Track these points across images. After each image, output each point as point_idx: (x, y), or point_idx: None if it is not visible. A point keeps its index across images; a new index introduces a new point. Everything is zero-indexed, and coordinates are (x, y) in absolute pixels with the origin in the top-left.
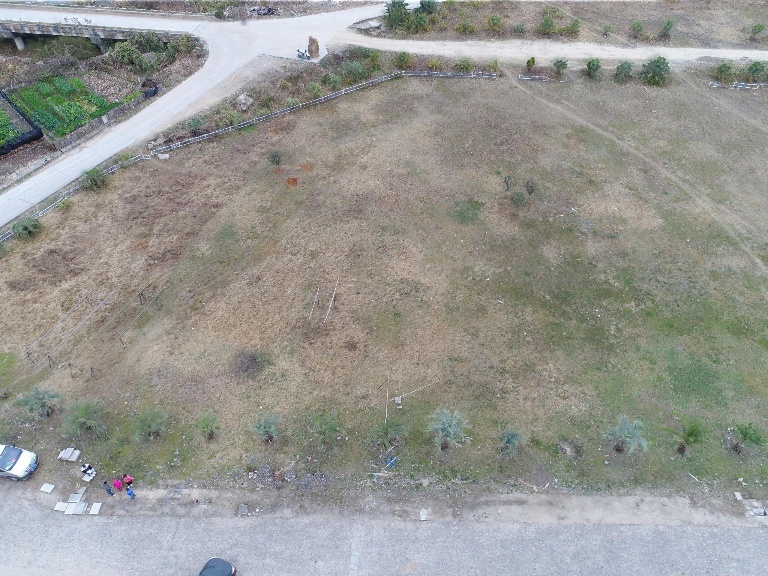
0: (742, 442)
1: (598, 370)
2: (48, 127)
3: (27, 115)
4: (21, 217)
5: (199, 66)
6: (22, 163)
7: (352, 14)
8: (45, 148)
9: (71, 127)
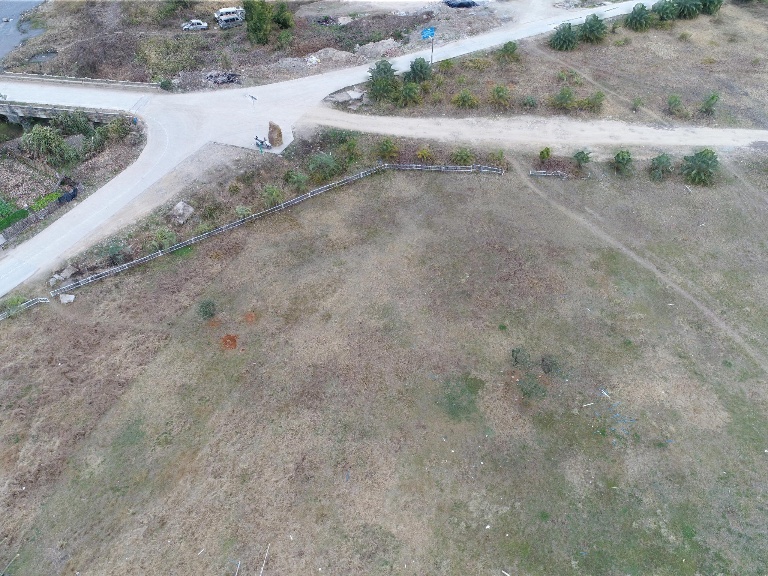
0: None
1: None
2: None
3: None
4: None
5: (133, 158)
6: None
7: (329, 80)
8: None
9: None
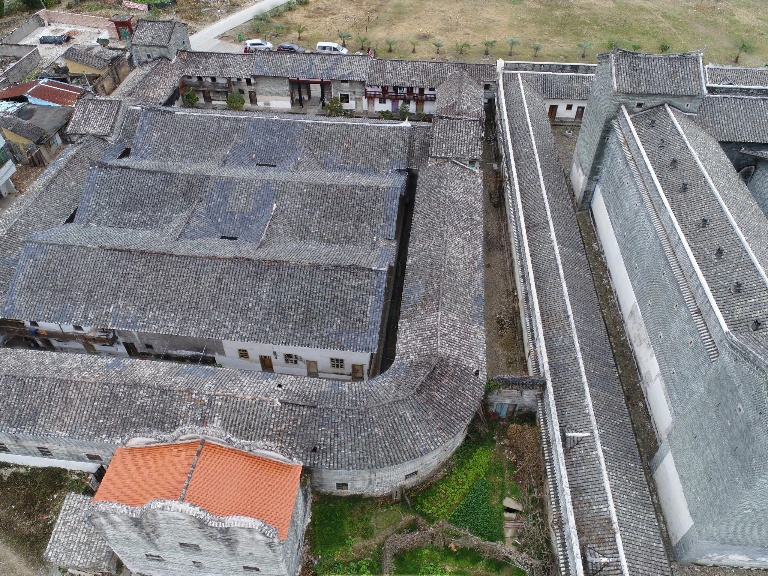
0: None
1: None
2: None
3: None
4: None
5: None
6: None
7: None
8: None
9: None
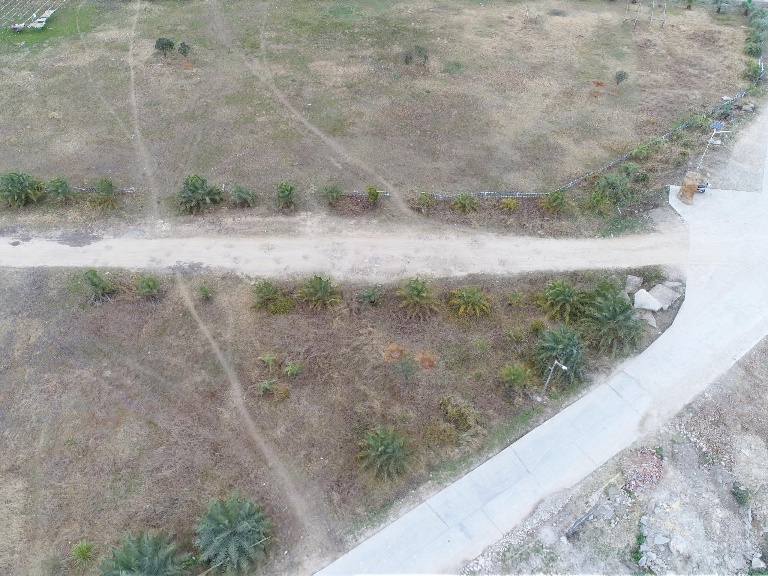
0: None
1: None
2: None
3: None
4: None
5: None
6: None
7: (712, 341)
8: None
9: None
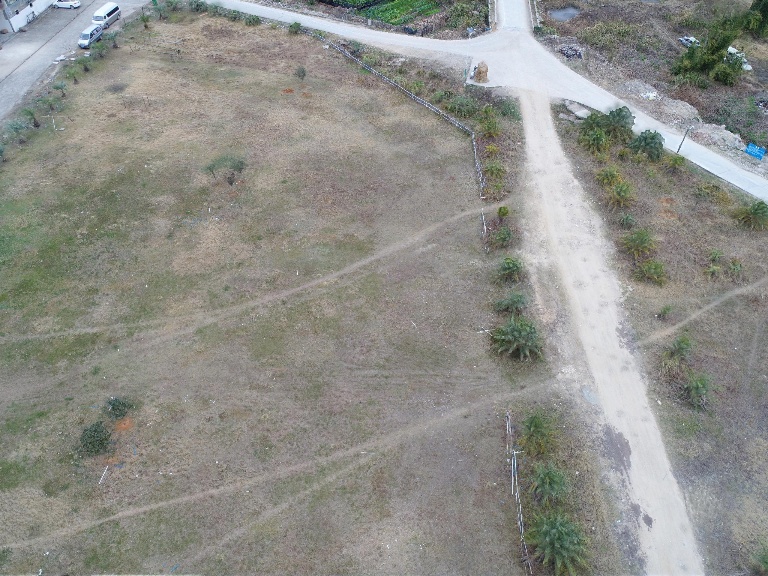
0: None
1: None
2: None
3: (381, 4)
4: (266, 19)
5: (451, 39)
6: (324, 12)
7: (608, 102)
8: None
9: None
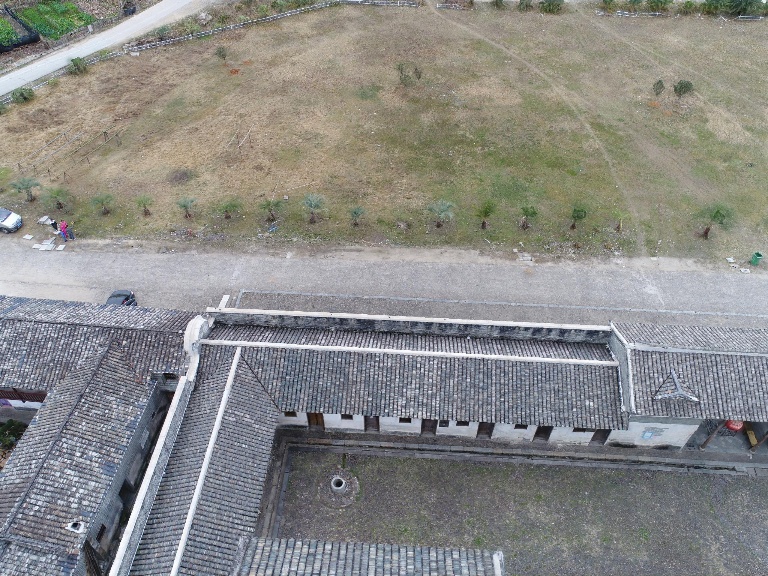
0: (526, 220)
1: (439, 184)
2: (44, 34)
3: None
4: None
5: None
6: (22, 57)
7: None
8: (41, 48)
9: (63, 34)
